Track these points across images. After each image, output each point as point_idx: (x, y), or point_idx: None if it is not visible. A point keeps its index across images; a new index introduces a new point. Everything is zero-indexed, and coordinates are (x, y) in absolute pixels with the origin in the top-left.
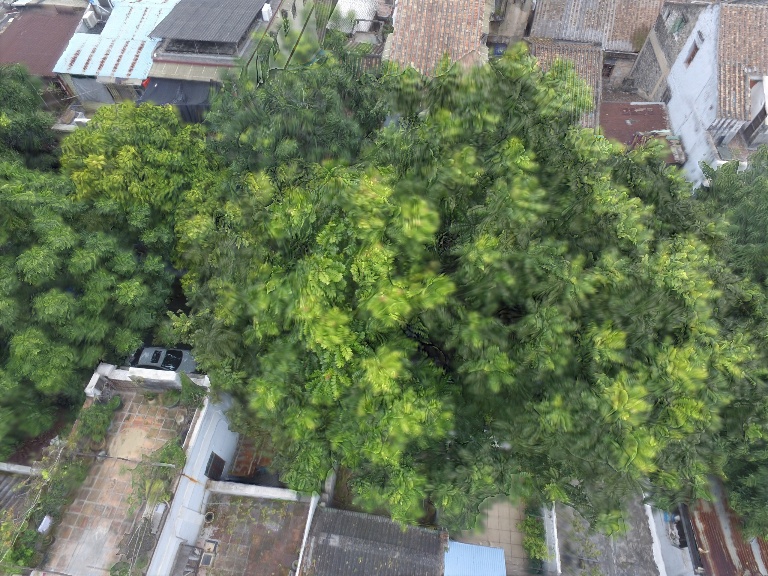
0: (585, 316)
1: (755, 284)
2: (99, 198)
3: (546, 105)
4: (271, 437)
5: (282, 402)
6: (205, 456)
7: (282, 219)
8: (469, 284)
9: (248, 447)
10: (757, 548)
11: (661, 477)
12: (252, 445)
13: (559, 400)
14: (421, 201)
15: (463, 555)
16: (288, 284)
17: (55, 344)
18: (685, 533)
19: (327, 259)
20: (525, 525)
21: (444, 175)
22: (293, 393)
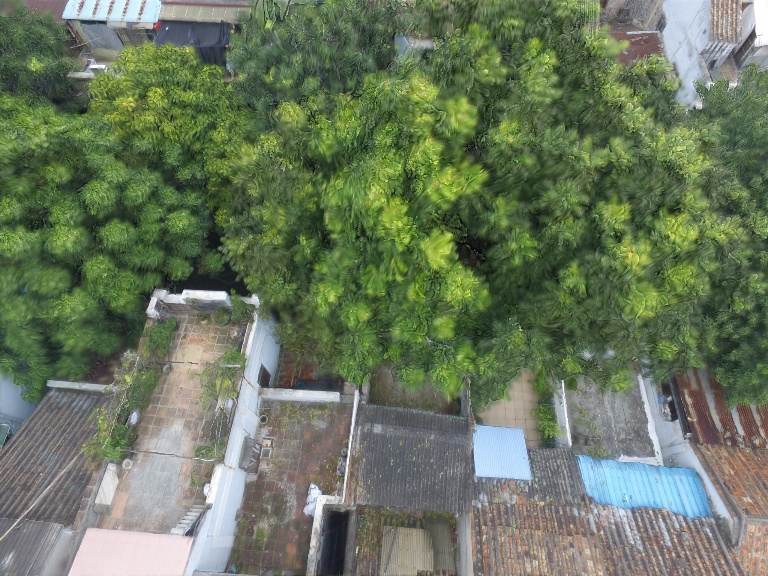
0: (602, 200)
1: (741, 186)
2: (130, 140)
3: (565, 19)
4: (322, 338)
5: (336, 301)
6: (257, 366)
7: (333, 135)
8: (503, 179)
9: (288, 364)
10: (737, 415)
11: (659, 350)
12: (292, 362)
13: (581, 270)
14: (459, 109)
15: (488, 434)
16: (337, 196)
17: (118, 270)
18: (676, 408)
19: (385, 160)
20: (539, 412)
21: (480, 84)
22: (346, 292)
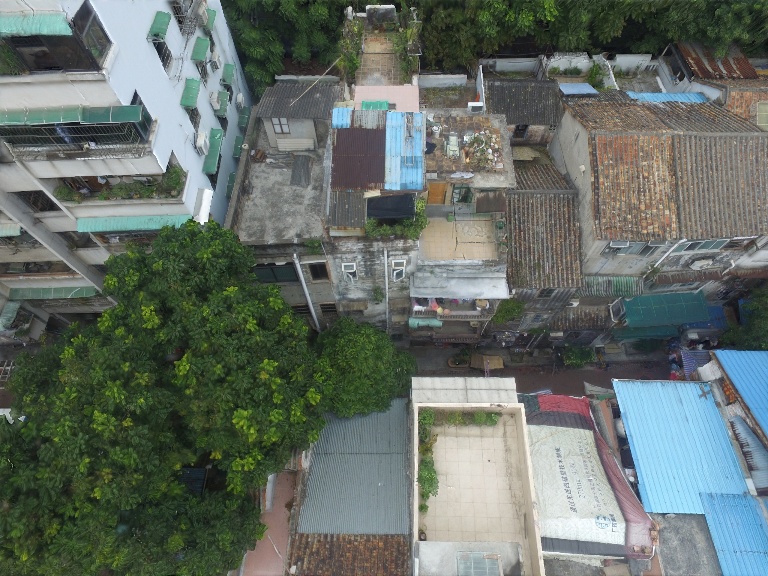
0: None
1: None
2: None
3: None
4: (470, 4)
5: None
6: None
7: None
8: None
9: None
10: (722, 66)
11: None
12: None
13: None
14: None
15: (567, 84)
16: None
17: None
18: (684, 71)
19: None
20: None
21: None
22: None
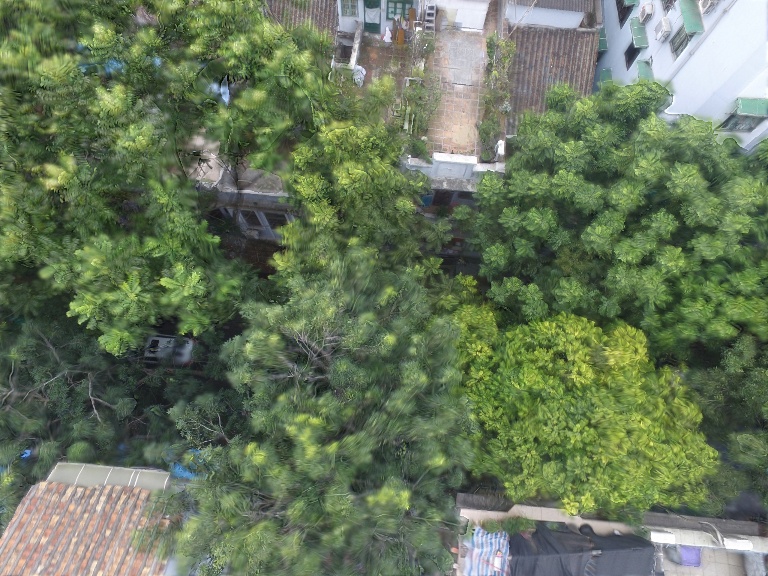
0: None
1: None
2: None
3: None
4: None
5: None
6: None
7: None
8: None
9: None
10: None
11: None
12: None
13: None
14: None
15: None
16: None
17: None
18: None
19: None
20: None
21: None
22: None
